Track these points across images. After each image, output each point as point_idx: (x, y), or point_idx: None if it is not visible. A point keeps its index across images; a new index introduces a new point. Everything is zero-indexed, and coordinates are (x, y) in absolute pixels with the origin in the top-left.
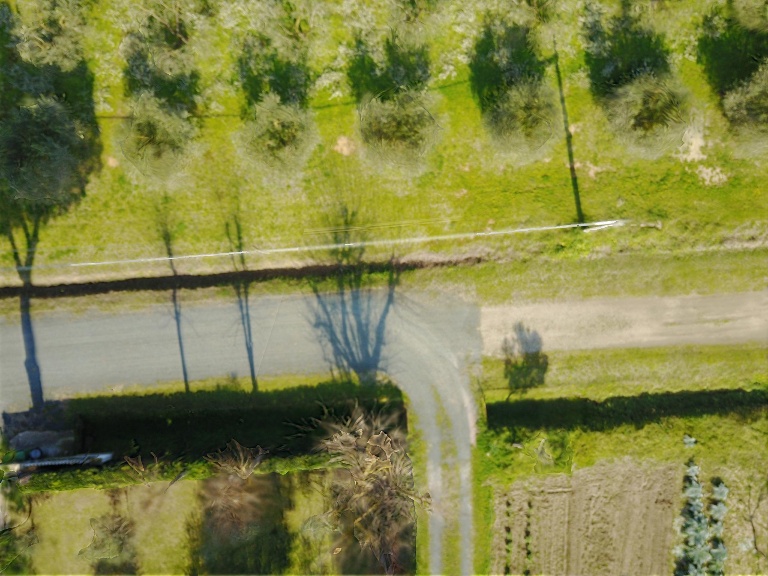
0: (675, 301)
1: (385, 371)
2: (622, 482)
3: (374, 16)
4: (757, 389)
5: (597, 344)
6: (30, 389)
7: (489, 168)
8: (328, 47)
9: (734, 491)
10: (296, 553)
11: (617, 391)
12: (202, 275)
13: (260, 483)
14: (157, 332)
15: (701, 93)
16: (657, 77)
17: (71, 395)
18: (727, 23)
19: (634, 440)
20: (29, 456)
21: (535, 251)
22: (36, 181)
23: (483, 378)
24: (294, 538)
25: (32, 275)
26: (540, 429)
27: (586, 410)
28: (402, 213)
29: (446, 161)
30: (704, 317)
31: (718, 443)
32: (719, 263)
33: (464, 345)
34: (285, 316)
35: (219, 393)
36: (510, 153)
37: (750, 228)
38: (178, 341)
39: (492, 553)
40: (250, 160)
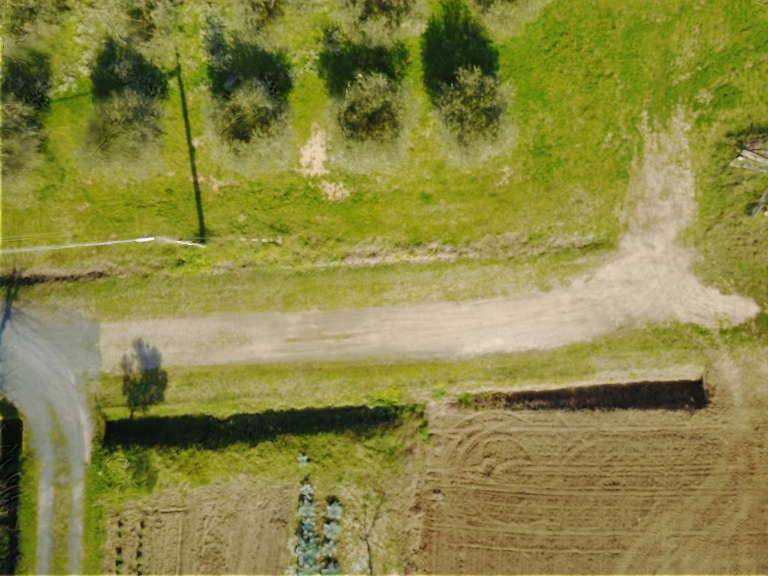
0: (297, 317)
1: (0, 388)
2: (237, 501)
3: None
4: (380, 406)
5: (217, 360)
6: None
7: (112, 181)
8: None
9: (350, 510)
10: None
11: (240, 408)
12: None
13: None
14: None
15: (323, 107)
16: (279, 91)
17: None
18: (345, 38)
19: (247, 458)
20: None
21: (157, 266)
22: None
23: (101, 395)
24: None
25: None
26: (153, 447)
27: (209, 428)
28: (22, 227)
29: (68, 174)
30: (325, 333)
31: (332, 461)
32: (340, 279)
33: (82, 361)
34: None
35: None
36: (131, 166)
37: (371, 244)
38: None
39: (102, 575)
40: None
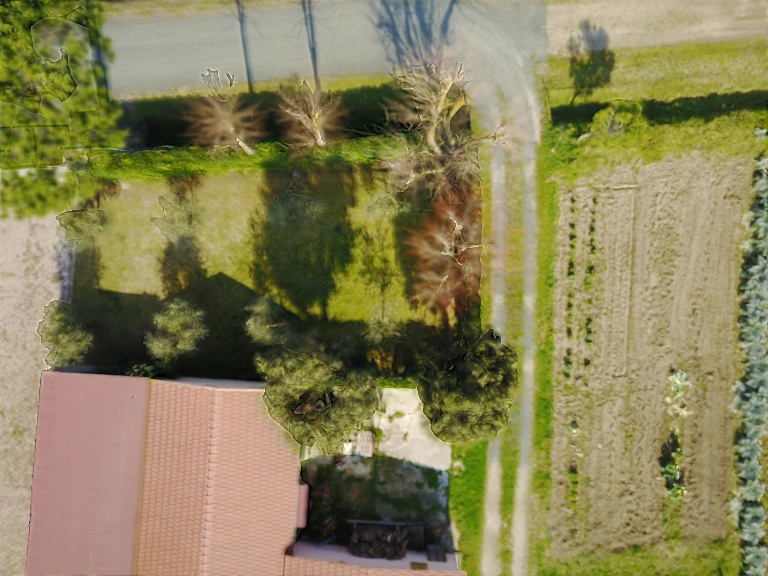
0: None
1: None
2: (690, 178)
3: None
4: None
5: (665, 41)
6: (96, 89)
7: None
8: None
9: None
10: (359, 248)
11: (685, 91)
12: None
13: (323, 180)
14: (220, 33)
15: None
16: None
17: (136, 95)
18: None
19: (703, 133)
20: (98, 144)
21: None
22: None
23: (548, 77)
24: (357, 234)
25: None
26: None
27: (653, 111)
28: None
29: None
30: None
31: None
32: None
33: (529, 44)
34: (348, 16)
35: (282, 94)
36: None
37: None
38: (241, 41)
39: (556, 249)
40: None
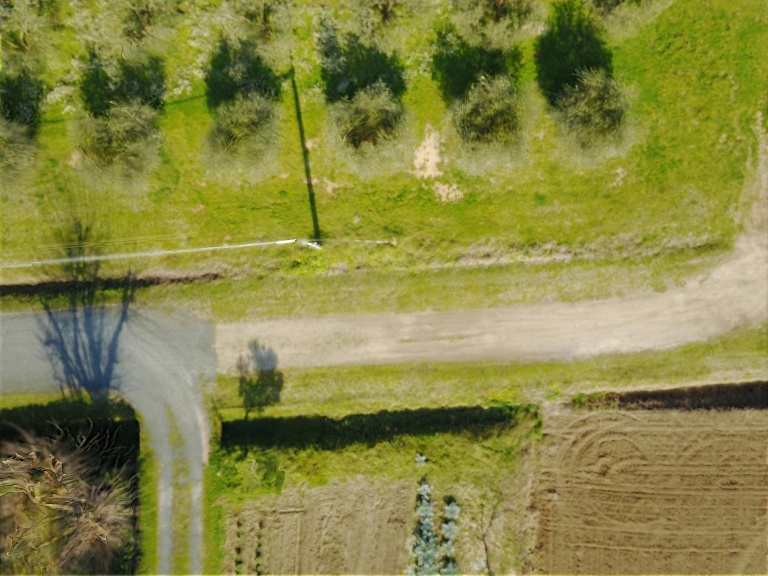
0: (411, 318)
1: (117, 390)
2: (354, 501)
3: (108, 30)
4: (494, 406)
5: (333, 361)
6: None
7: (226, 184)
8: (61, 60)
9: (467, 510)
10: None
11: (355, 409)
12: None
13: None
14: None
15: (436, 109)
16: (393, 93)
17: None
18: (460, 40)
19: (365, 459)
20: None
21: (272, 267)
22: None
23: (217, 396)
24: (17, 562)
25: None
26: (271, 448)
27: (324, 428)
28: (137, 229)
29: (183, 176)
30: (440, 334)
31: (450, 461)
32: (454, 280)
33: (198, 363)
34: (15, 334)
35: None
36: (246, 169)
37: (485, 245)
38: None
39: (222, 575)
40: None
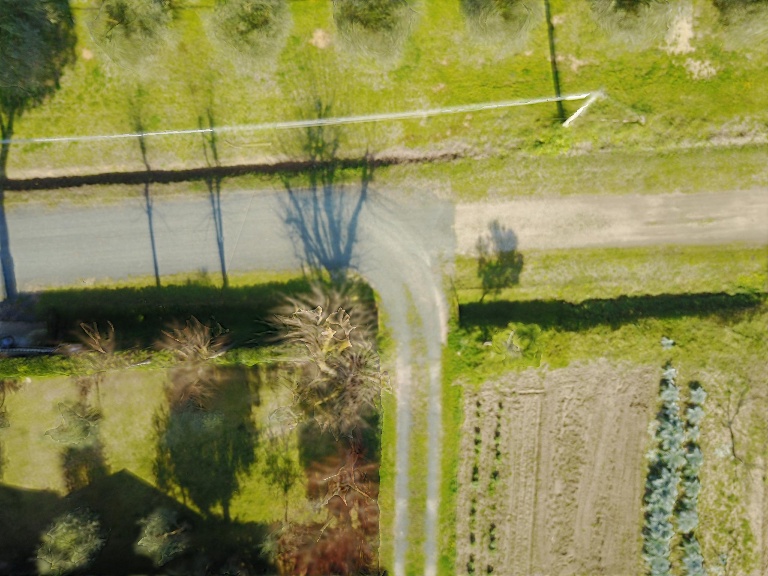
0: (657, 200)
1: (356, 268)
2: (596, 384)
3: None
4: (741, 293)
5: (574, 244)
6: (4, 280)
7: (467, 62)
8: None
9: (713, 396)
10: (264, 447)
11: (594, 293)
12: (175, 170)
13: (229, 377)
14: (129, 225)
15: None
16: None
17: (44, 286)
18: None
19: (609, 341)
20: (1, 343)
21: (513, 148)
22: (5, 63)
23: (456, 277)
24: (262, 433)
25: (7, 167)
26: None
27: (562, 312)
28: (377, 108)
29: (423, 54)
30: (687, 217)
31: (697, 346)
32: (705, 161)
33: (437, 243)
34: (256, 211)
35: (190, 288)
36: (489, 45)
37: (739, 124)
38: (150, 235)
39: (461, 453)
40: (223, 53)
